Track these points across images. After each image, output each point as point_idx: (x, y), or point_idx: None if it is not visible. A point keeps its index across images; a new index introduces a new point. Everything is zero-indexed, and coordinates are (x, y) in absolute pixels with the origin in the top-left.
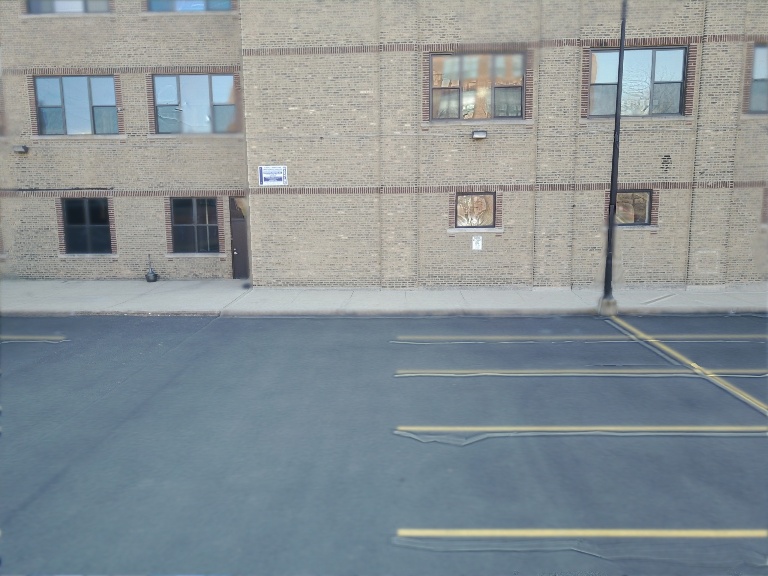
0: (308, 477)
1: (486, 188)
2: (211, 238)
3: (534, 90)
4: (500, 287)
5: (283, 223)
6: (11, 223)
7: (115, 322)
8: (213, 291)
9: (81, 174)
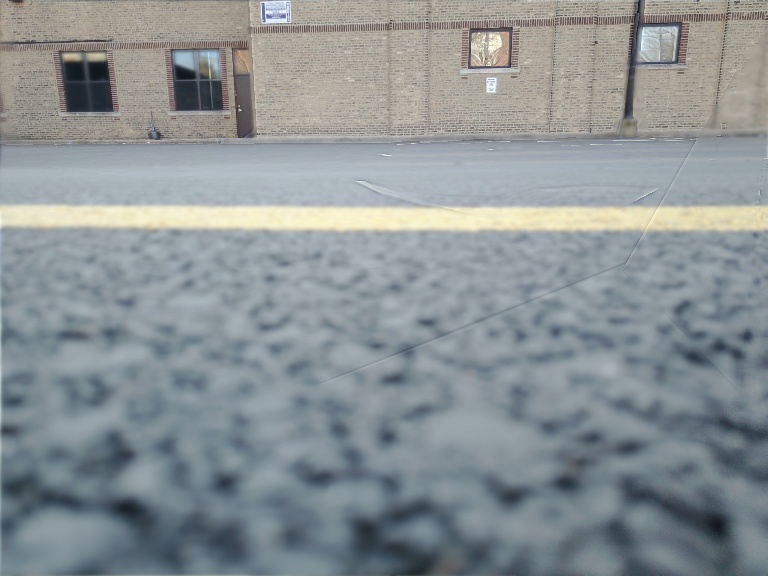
0: None
1: (502, 23)
2: (214, 94)
3: None
4: None
5: (287, 65)
6: (10, 79)
7: None
8: None
9: (78, 25)
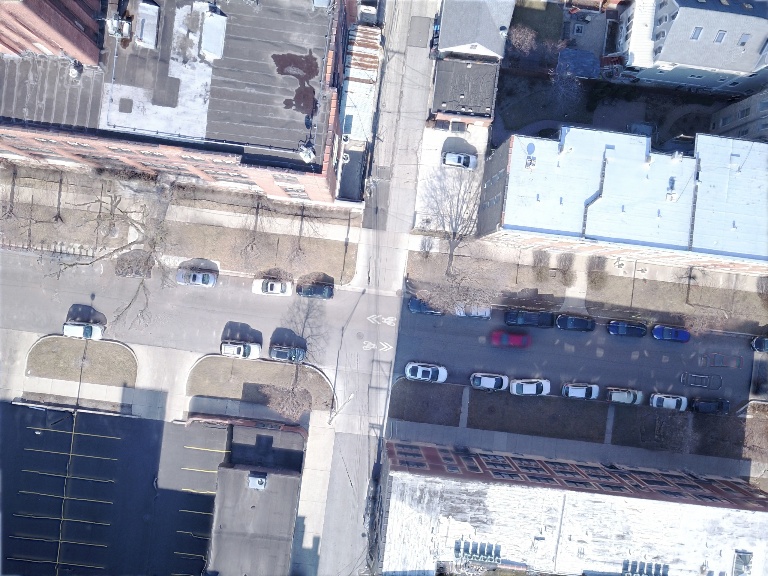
0: (117, 537)
1: None
2: None
3: None
4: None
5: None
6: None
7: None
8: None
9: None
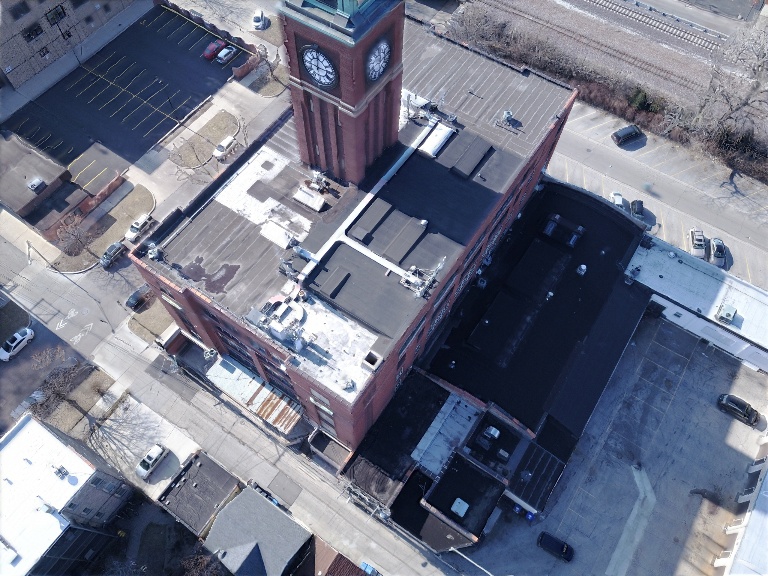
0: None
1: None
2: None
3: (41, 27)
4: (55, 62)
5: None
6: None
7: (23, 112)
8: (11, 96)
9: None
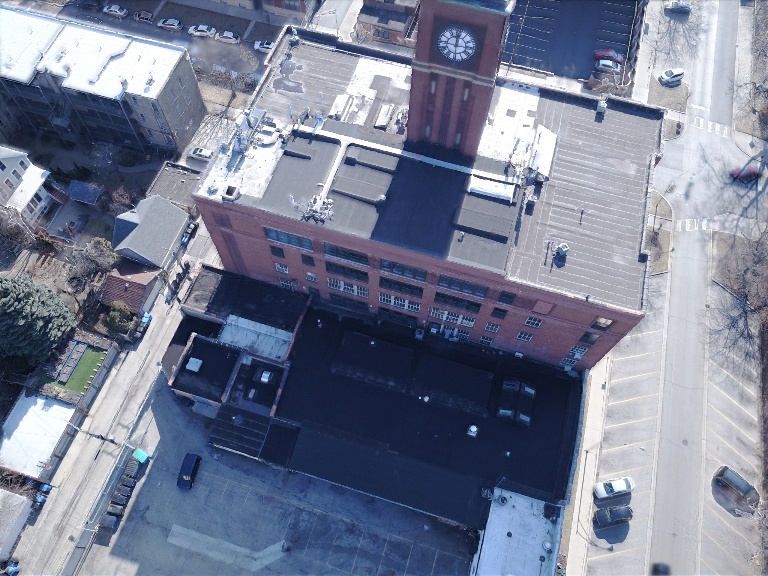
0: None
1: None
2: None
3: None
4: None
5: None
6: None
7: None
8: None
9: None
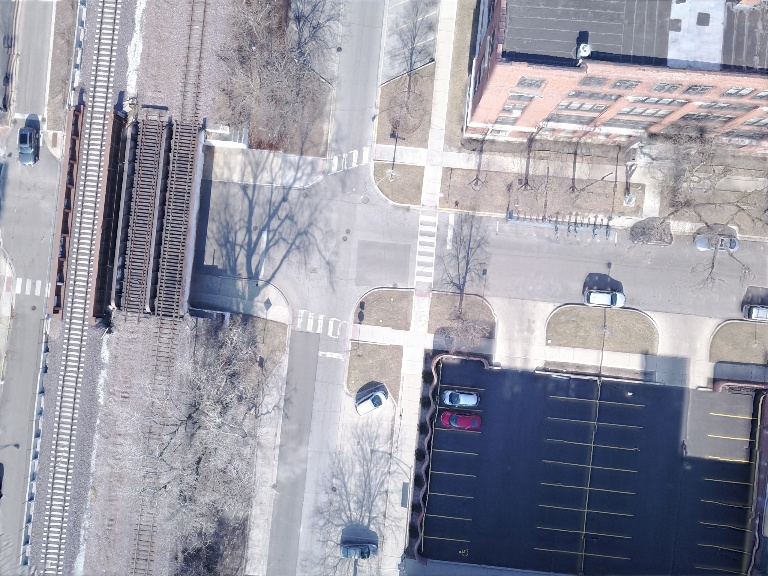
0: (643, 506)
1: None
2: None
3: None
4: None
5: None
6: None
7: None
8: None
9: None
